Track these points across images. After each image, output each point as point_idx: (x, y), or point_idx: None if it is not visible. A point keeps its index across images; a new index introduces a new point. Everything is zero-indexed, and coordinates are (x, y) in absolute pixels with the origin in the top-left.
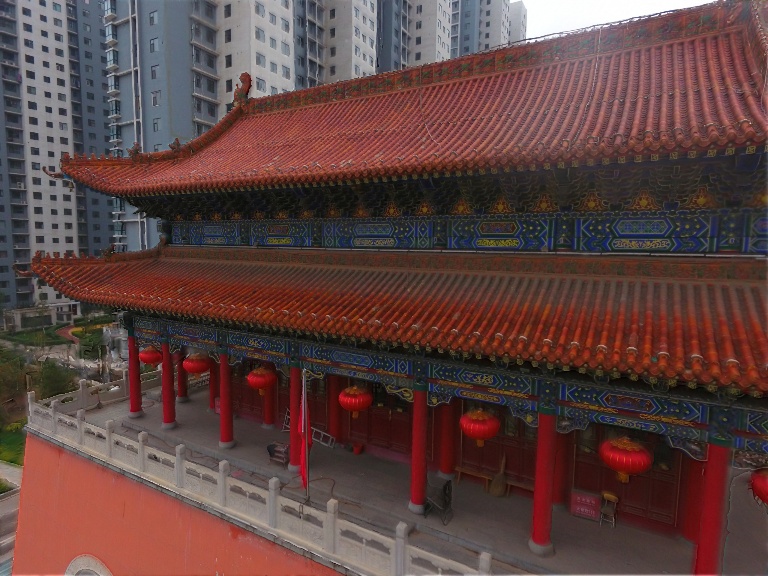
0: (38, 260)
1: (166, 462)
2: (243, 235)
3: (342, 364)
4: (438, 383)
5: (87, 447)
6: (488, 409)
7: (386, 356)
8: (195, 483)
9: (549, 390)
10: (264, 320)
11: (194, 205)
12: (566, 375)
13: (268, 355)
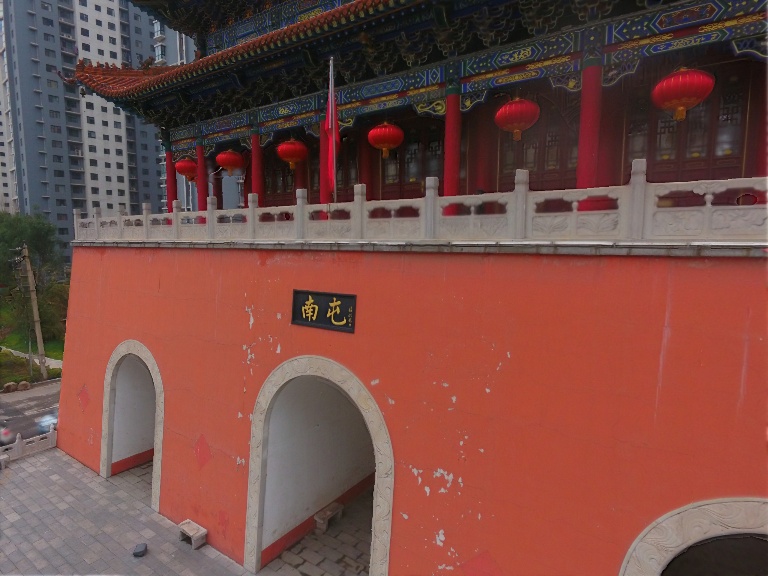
0: (81, 69)
1: (198, 221)
2: (274, 21)
3: (372, 100)
4: (472, 81)
5: (126, 238)
6: (526, 95)
7: (417, 71)
8: (225, 229)
9: (593, 36)
10: (291, 30)
11: (227, 2)
12: (613, 15)
13: (298, 119)
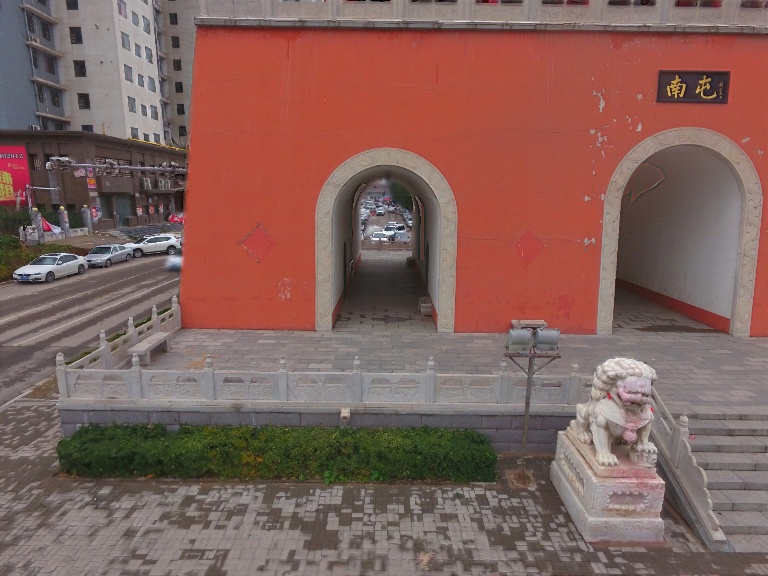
0: None
1: None
2: None
3: None
4: None
5: (353, 17)
6: None
7: None
8: (556, 11)
9: None
10: None
11: None
12: None
13: None
